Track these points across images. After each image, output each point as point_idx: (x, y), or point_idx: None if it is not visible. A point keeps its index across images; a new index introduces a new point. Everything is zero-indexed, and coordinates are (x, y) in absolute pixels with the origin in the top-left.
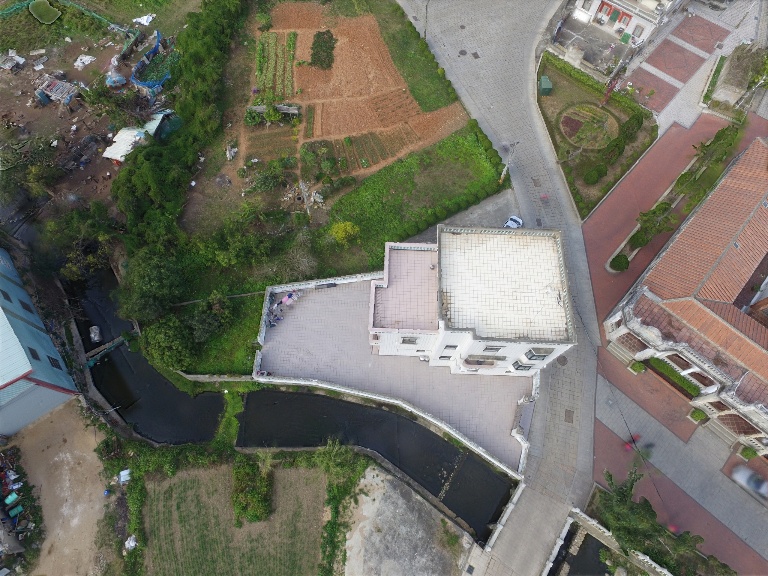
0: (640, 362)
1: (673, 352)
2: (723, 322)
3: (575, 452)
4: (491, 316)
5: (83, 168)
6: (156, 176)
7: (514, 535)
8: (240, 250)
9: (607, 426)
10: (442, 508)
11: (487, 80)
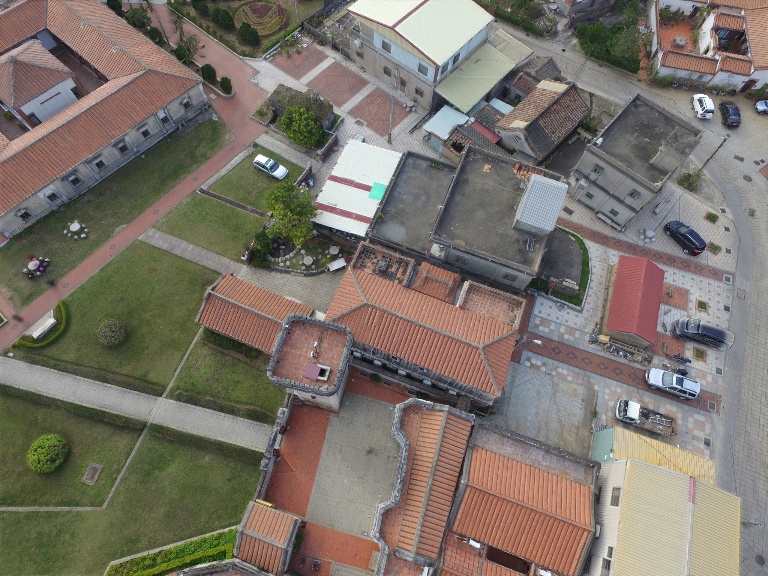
0: None
1: None
2: (25, 1)
3: None
4: None
5: None
6: None
7: None
8: None
9: None
10: None
11: None
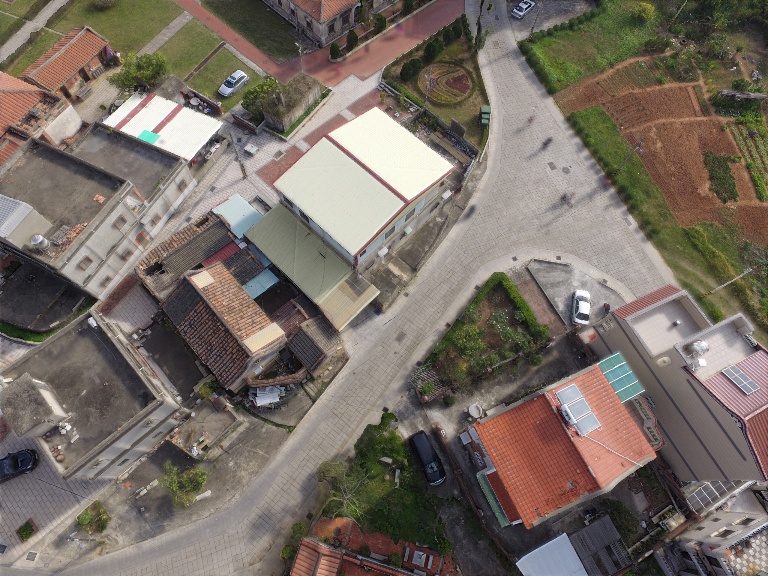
0: None
1: None
2: None
3: None
4: None
5: None
6: None
7: None
8: None
9: None
10: None
11: (539, 136)
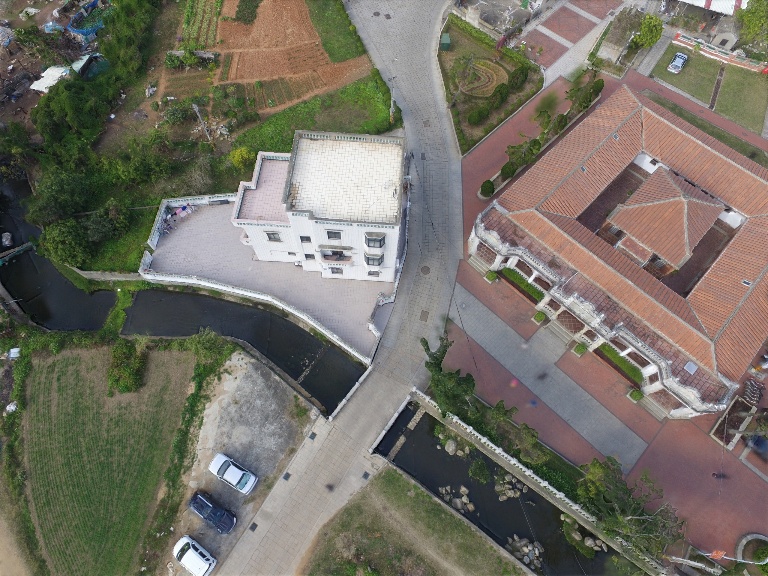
0: None
1: (516, 258)
2: (558, 229)
3: None
4: (331, 204)
5: (14, 101)
6: (73, 103)
7: (357, 409)
8: (139, 165)
9: (457, 325)
10: (299, 389)
11: (395, 37)
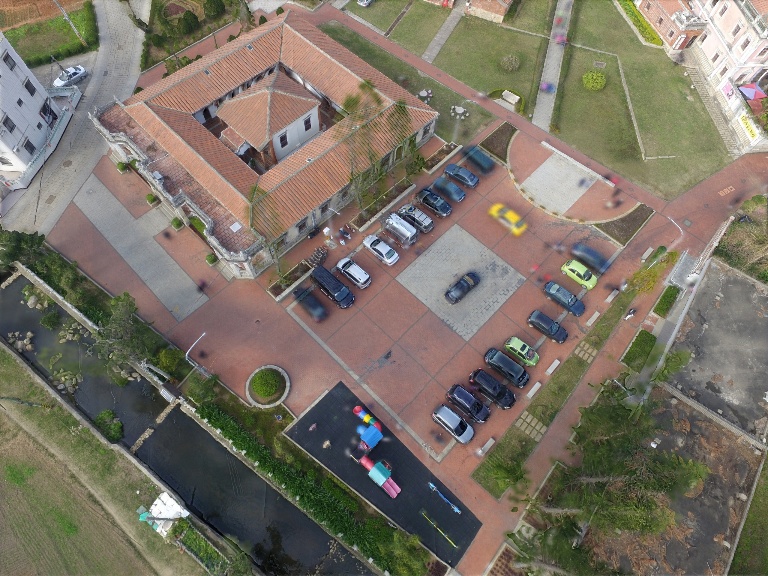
0: (126, 164)
1: None
2: (157, 118)
3: (41, 222)
4: None
5: None
6: None
7: None
8: None
9: (78, 206)
10: None
11: None
